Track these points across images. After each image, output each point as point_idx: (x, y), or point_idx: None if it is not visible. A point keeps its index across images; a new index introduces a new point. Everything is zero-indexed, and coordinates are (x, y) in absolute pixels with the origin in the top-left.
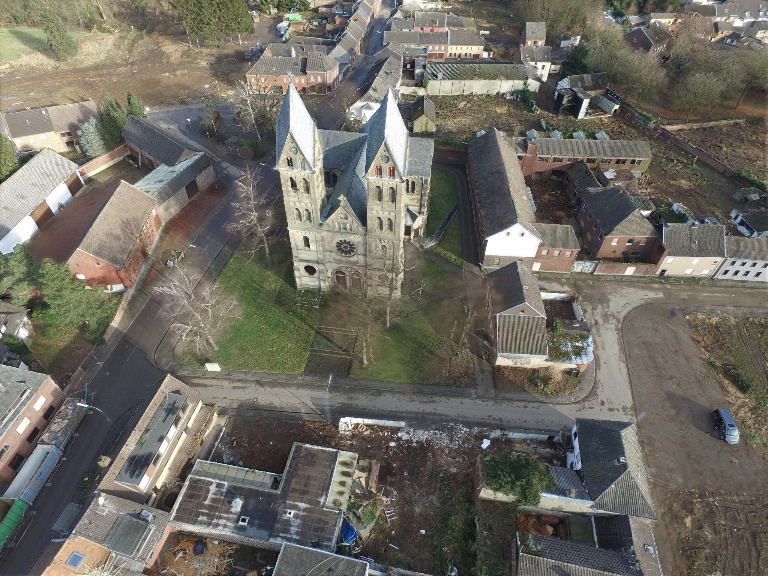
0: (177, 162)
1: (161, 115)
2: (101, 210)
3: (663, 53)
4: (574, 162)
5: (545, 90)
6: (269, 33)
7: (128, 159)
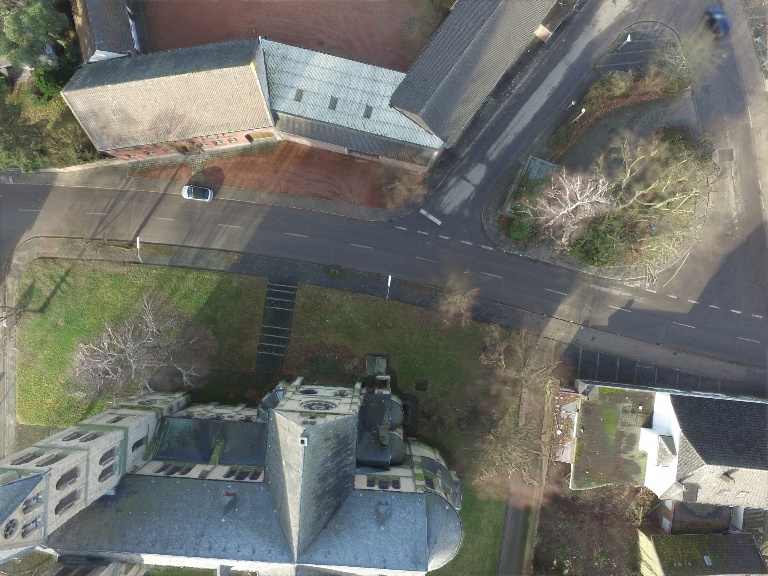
0: (399, 108)
1: None
2: (186, 65)
3: None
4: None
5: None
6: None
7: None
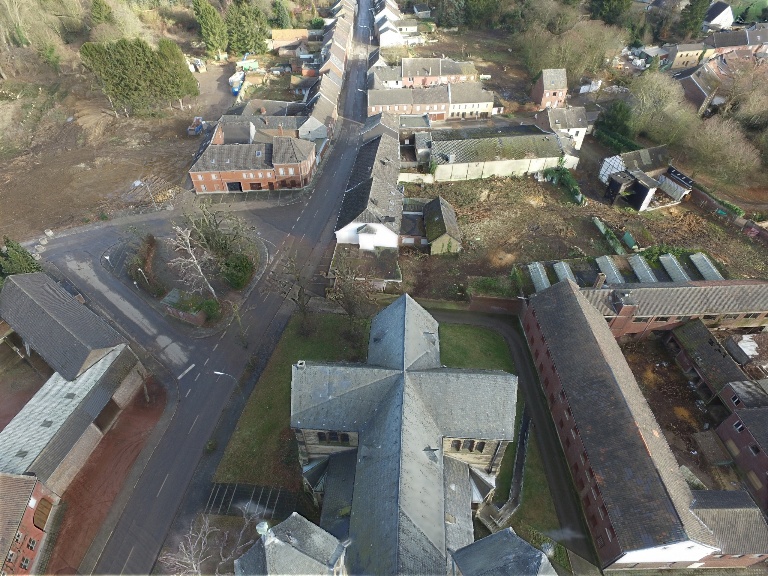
0: (79, 372)
1: (69, 243)
2: None
3: (710, 102)
4: (684, 320)
5: (583, 164)
6: (219, 89)
7: (9, 344)
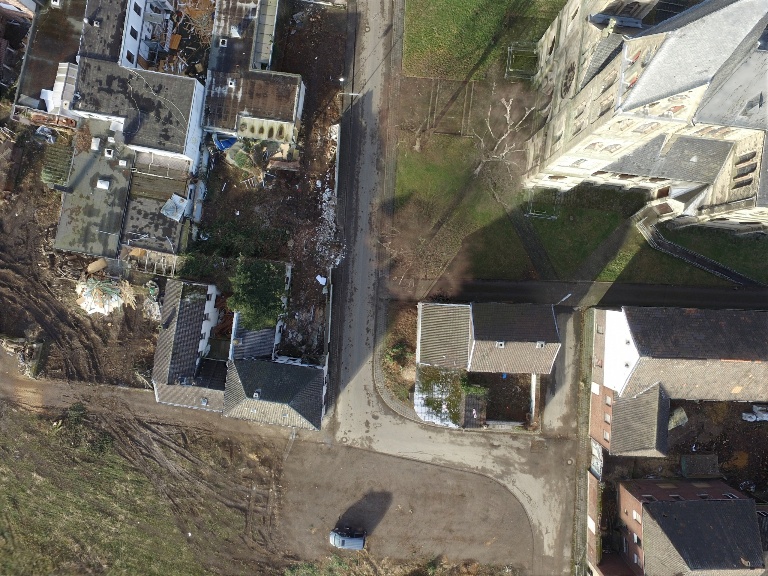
0: None
1: None
2: None
3: None
4: None
5: None
6: None
7: None
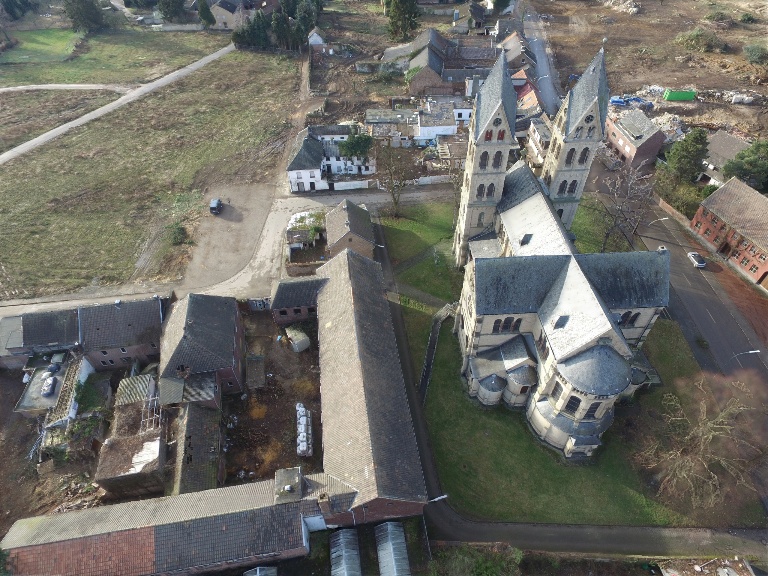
0: None
1: None
2: None
3: None
4: None
5: None
6: None
7: None
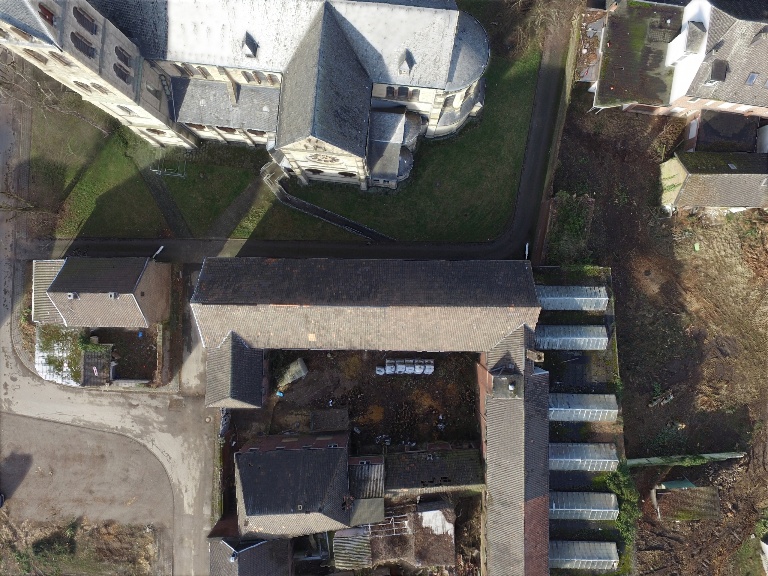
0: None
1: None
2: None
3: None
4: None
5: None
6: None
7: None
